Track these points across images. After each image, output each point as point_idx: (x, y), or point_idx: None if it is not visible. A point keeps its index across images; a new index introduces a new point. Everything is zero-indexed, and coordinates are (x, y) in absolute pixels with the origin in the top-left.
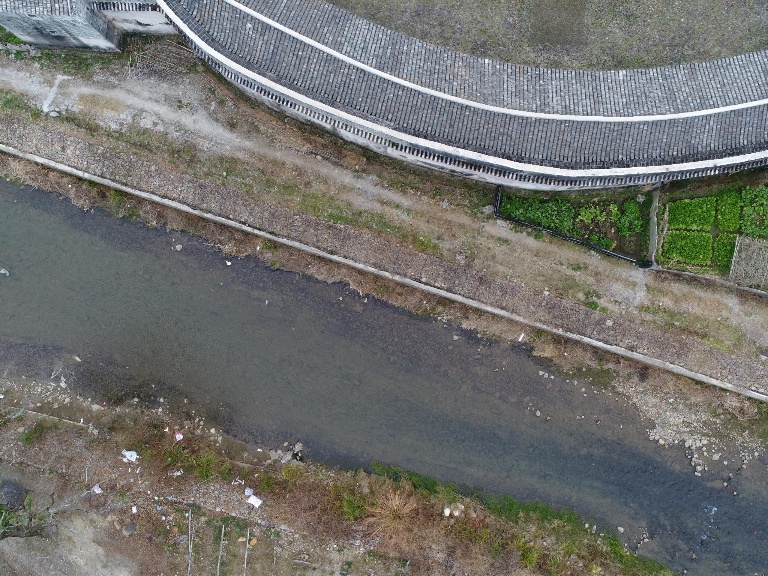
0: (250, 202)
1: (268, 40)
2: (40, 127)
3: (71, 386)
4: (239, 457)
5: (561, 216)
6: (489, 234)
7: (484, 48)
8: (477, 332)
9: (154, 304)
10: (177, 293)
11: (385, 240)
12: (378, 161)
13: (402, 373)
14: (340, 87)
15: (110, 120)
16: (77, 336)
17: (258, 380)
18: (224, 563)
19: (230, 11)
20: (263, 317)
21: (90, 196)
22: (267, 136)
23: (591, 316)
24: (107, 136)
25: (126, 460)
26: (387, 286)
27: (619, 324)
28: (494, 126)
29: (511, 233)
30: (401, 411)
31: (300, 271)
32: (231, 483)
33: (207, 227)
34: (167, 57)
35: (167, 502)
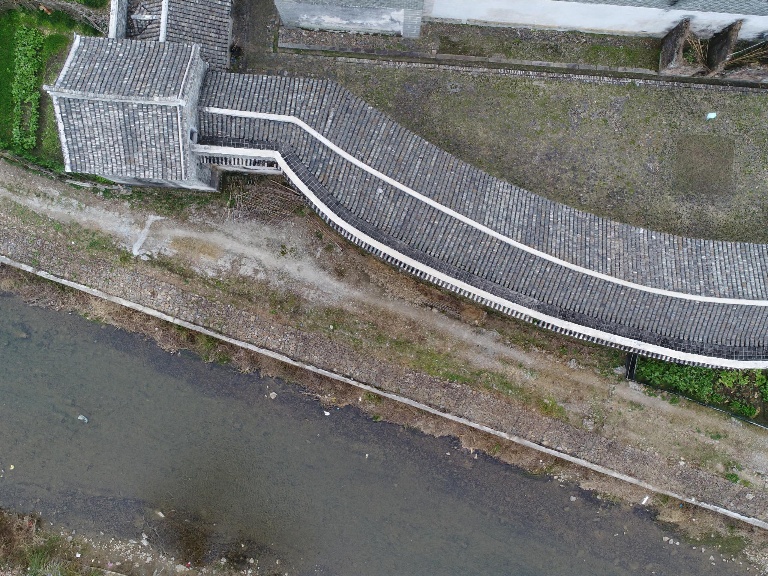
0: (358, 357)
1: (401, 207)
2: (129, 271)
3: (153, 543)
4: None
5: (701, 380)
6: (620, 397)
7: (621, 196)
8: (597, 493)
9: (244, 455)
10: (270, 444)
11: (506, 402)
12: (500, 316)
13: (513, 535)
14: (479, 259)
15: (207, 266)
16: (160, 489)
17: (356, 540)
18: None
19: (359, 174)
20: (363, 471)
21: (179, 340)
22: (378, 285)
23: (730, 488)
24: (203, 283)
25: None
26: (501, 443)
27: (761, 498)
28: (652, 307)
29: (644, 396)
30: None
31: (405, 424)
32: None
33: (305, 376)
34: (271, 199)
35: None
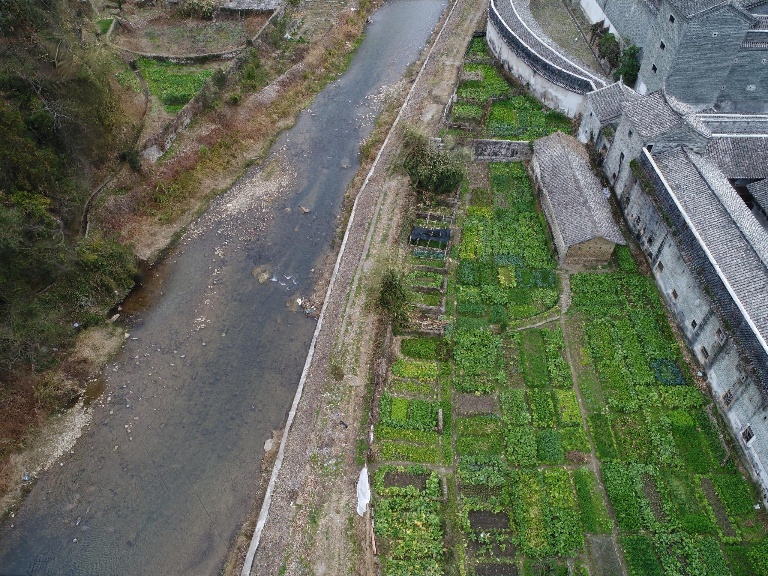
0: None
1: None
2: None
3: None
4: (367, 13)
5: None
6: None
7: None
8: None
9: None
10: None
11: None
12: None
13: None
14: None
15: None
16: None
17: None
18: (330, 2)
19: None
20: None
21: None
22: None
23: None
24: None
25: None
26: None
27: None
28: None
29: None
30: None
31: None
32: (358, 8)
33: None
34: None
35: None
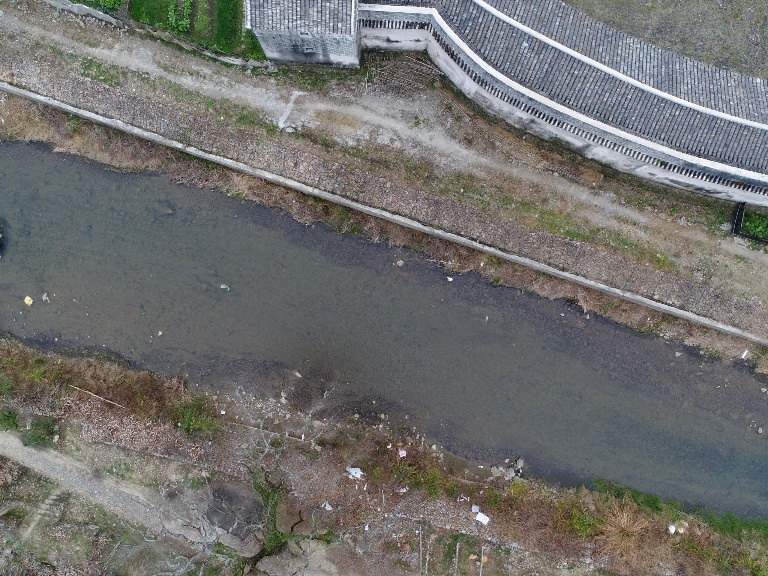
0: (485, 219)
1: (543, 59)
2: (274, 143)
3: (291, 402)
4: (460, 474)
5: None
6: (726, 251)
7: (726, 65)
8: (699, 349)
9: (374, 320)
10: (397, 309)
11: (621, 257)
12: (616, 178)
13: (623, 390)
14: (614, 106)
15: (347, 136)
16: (297, 352)
17: (478, 396)
18: None
19: (507, 30)
20: (483, 333)
21: (315, 212)
22: (503, 153)
23: None
24: (343, 152)
25: (351, 477)
26: (612, 303)
27: None
28: None
29: (748, 251)
30: (622, 428)
31: (523, 287)
32: (457, 500)
33: (431, 243)
34: (405, 73)
35: (396, 519)
